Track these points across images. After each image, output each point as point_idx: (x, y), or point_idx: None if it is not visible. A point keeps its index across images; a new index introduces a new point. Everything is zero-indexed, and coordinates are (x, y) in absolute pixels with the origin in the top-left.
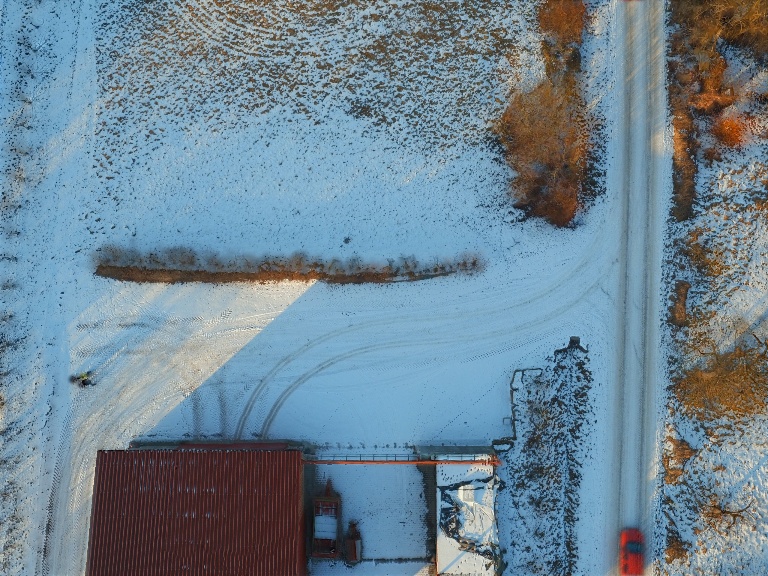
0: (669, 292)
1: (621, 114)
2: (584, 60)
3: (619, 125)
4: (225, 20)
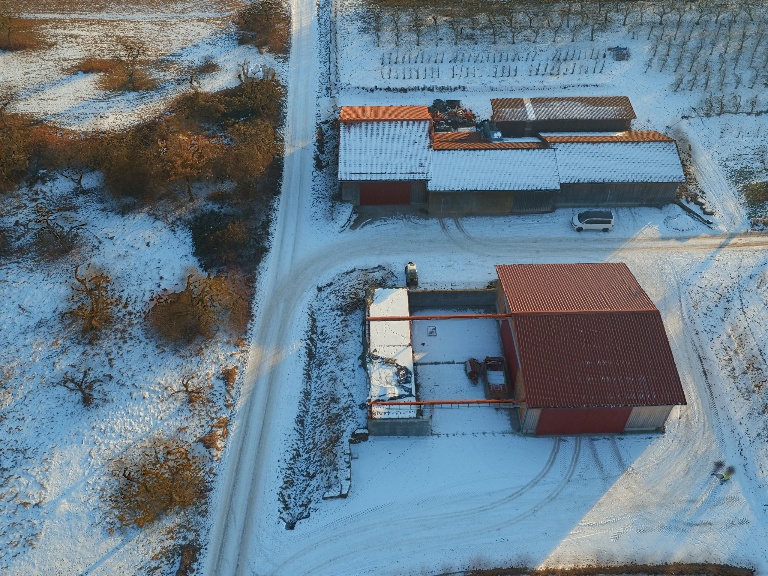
0: None
1: None
2: None
3: None
4: None
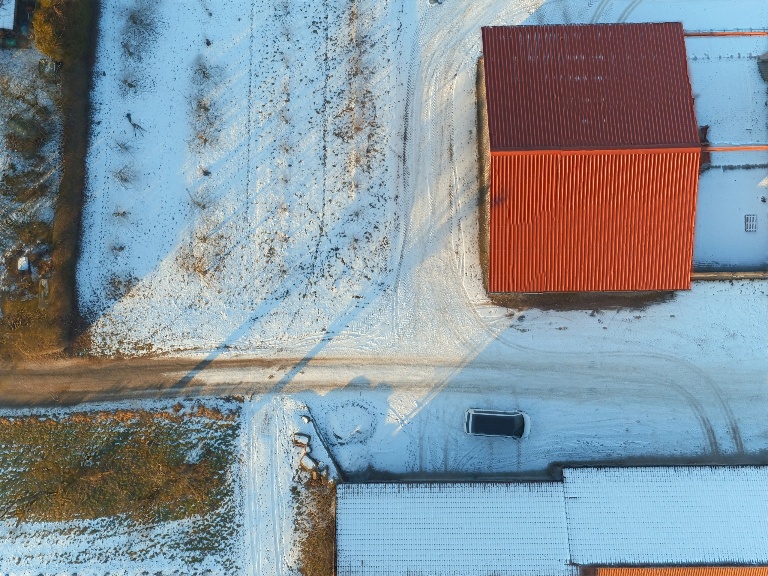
0: None
1: None
2: None
3: None
4: None
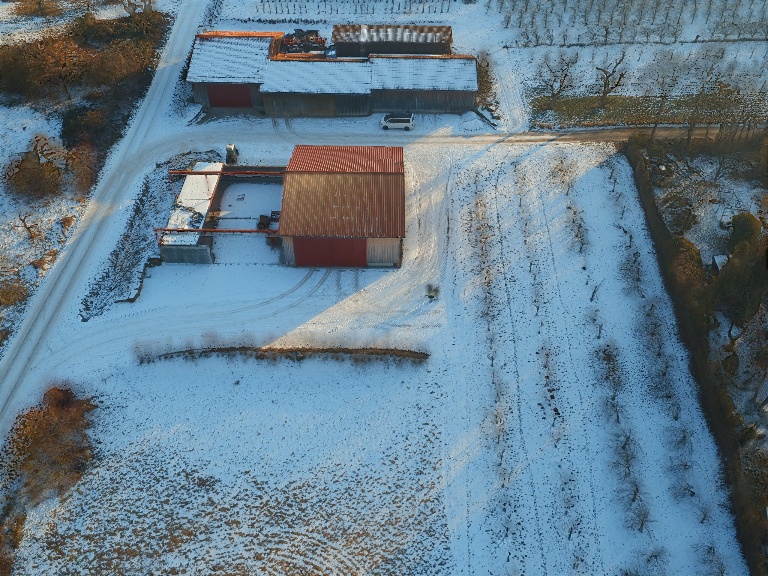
0: (2, 349)
1: None
2: None
3: None
4: (324, 569)
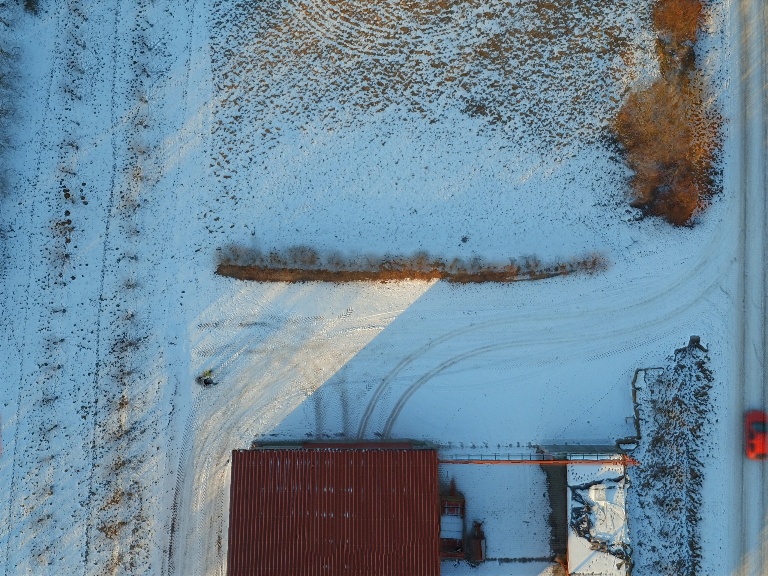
0: None
1: (737, 112)
2: (698, 58)
3: (735, 123)
4: (339, 18)
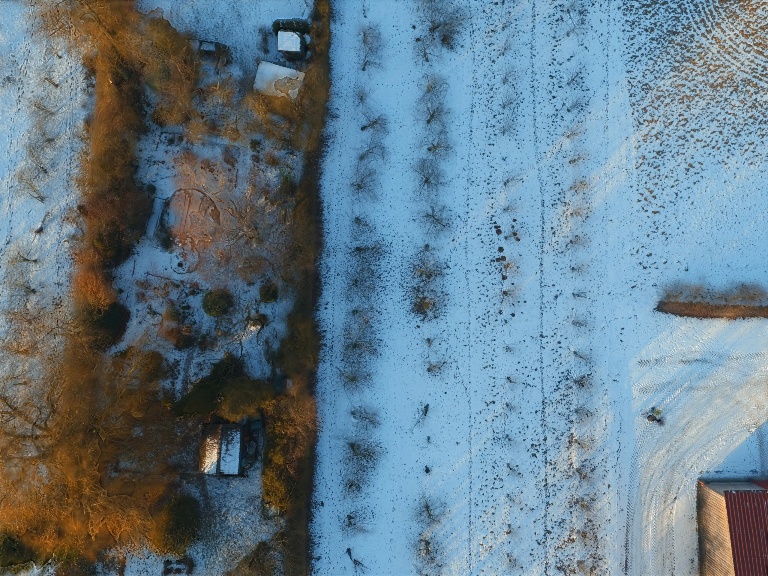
0: None
1: None
2: None
3: None
4: (752, 52)
